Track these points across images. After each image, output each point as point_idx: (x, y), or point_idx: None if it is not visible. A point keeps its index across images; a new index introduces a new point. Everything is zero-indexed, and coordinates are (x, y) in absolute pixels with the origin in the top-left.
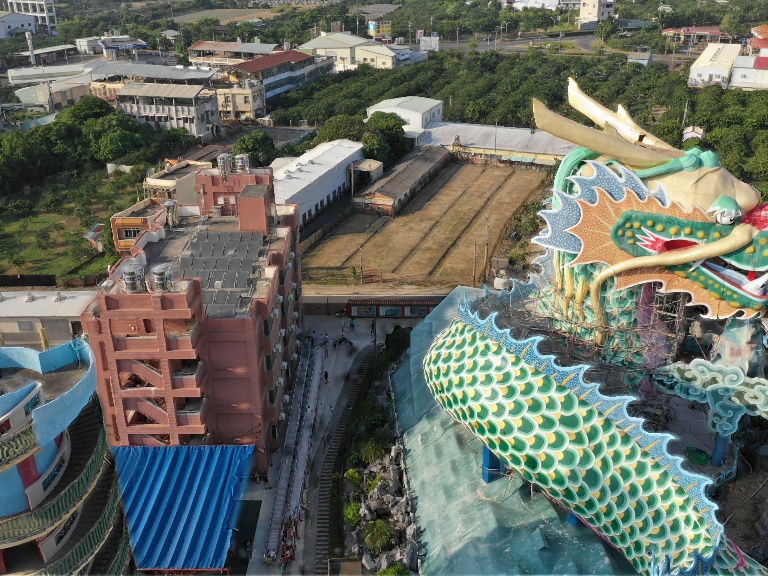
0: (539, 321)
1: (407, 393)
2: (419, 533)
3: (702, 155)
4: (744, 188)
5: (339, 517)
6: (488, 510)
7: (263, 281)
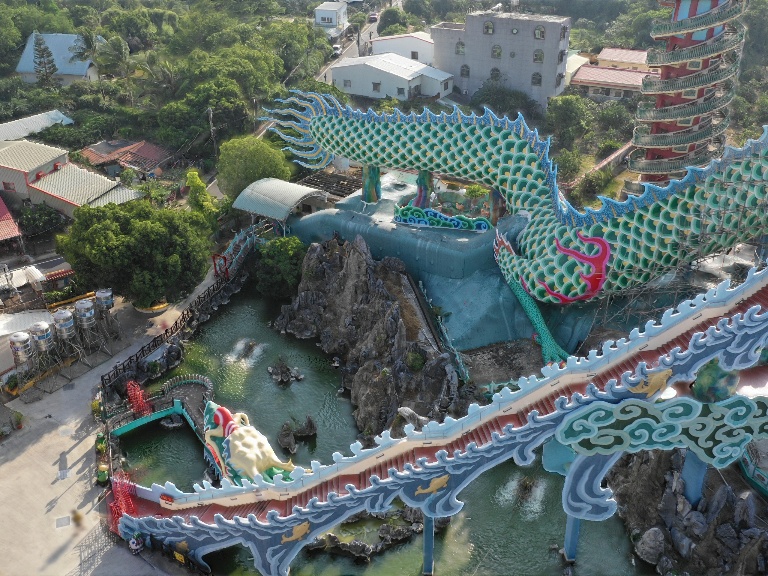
0: None
1: None
2: None
3: None
4: None
5: None
6: None
7: None
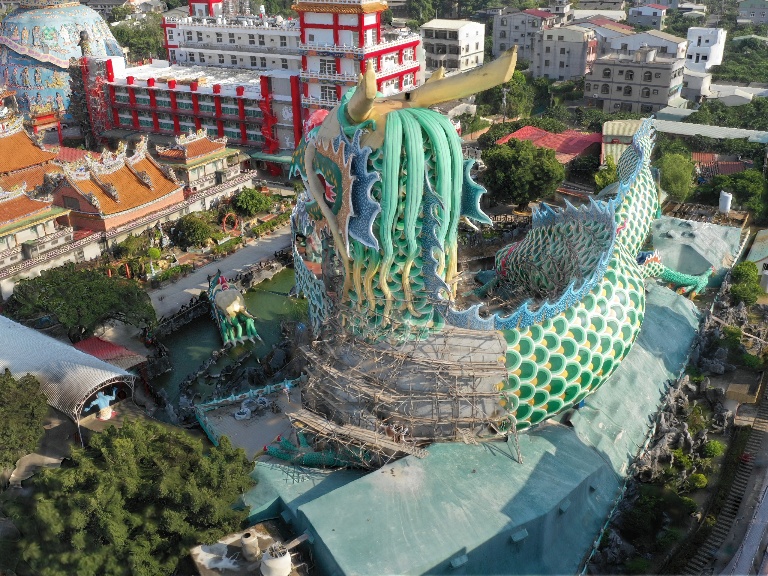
0: None
1: None
2: None
3: None
4: None
5: None
6: None
7: None
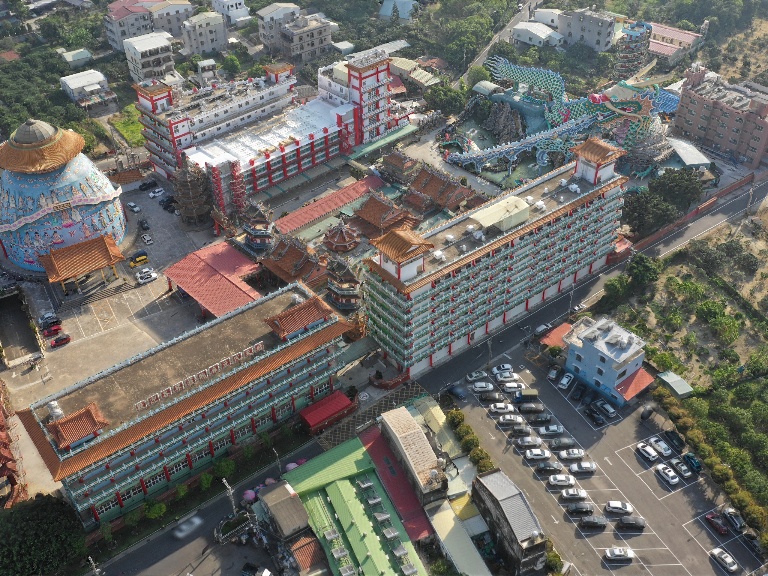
0: None
1: None
2: None
3: None
4: None
5: None
6: None
7: (705, 95)
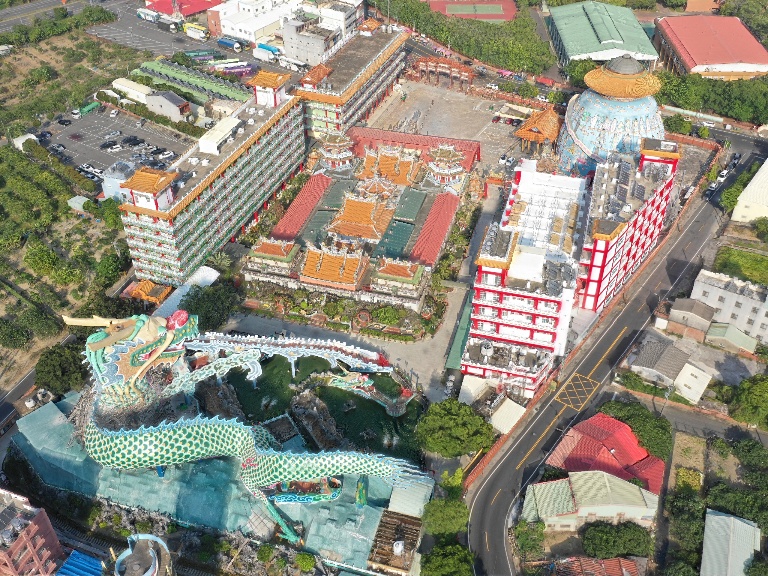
0: (113, 411)
1: (73, 482)
2: (158, 512)
3: (142, 318)
4: (161, 320)
5: (117, 541)
6: (177, 483)
7: (6, 496)
